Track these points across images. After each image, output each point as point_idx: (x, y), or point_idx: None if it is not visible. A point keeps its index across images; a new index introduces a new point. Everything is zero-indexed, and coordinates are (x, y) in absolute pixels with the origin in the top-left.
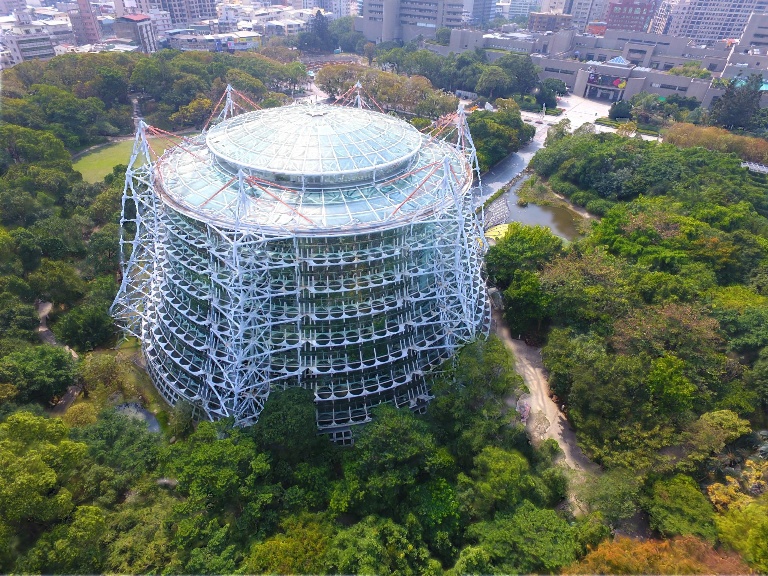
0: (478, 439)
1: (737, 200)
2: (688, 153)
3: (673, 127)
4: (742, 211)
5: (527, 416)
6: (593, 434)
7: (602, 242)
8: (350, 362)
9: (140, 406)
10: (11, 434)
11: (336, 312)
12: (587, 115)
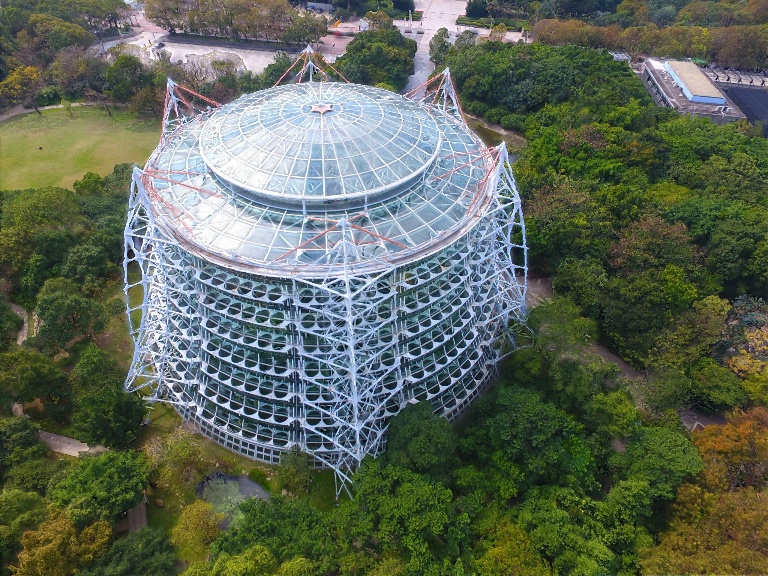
0: (581, 391)
1: (628, 97)
2: (572, 55)
3: (540, 25)
4: (637, 108)
5: None
6: (638, 349)
7: (548, 164)
8: (437, 359)
9: (223, 474)
10: None
11: (424, 321)
12: (445, 15)
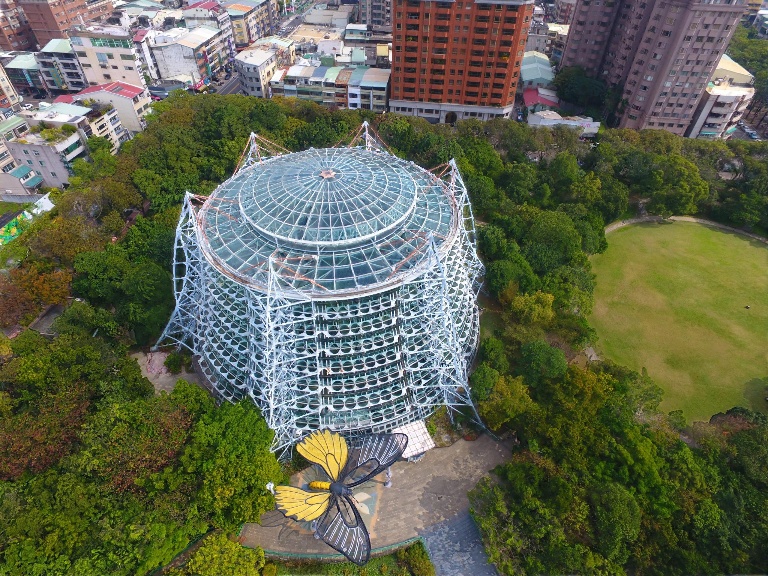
0: None
1: None
2: None
3: None
4: None
5: (147, 366)
6: None
7: None
8: None
9: None
10: None
11: None
12: None
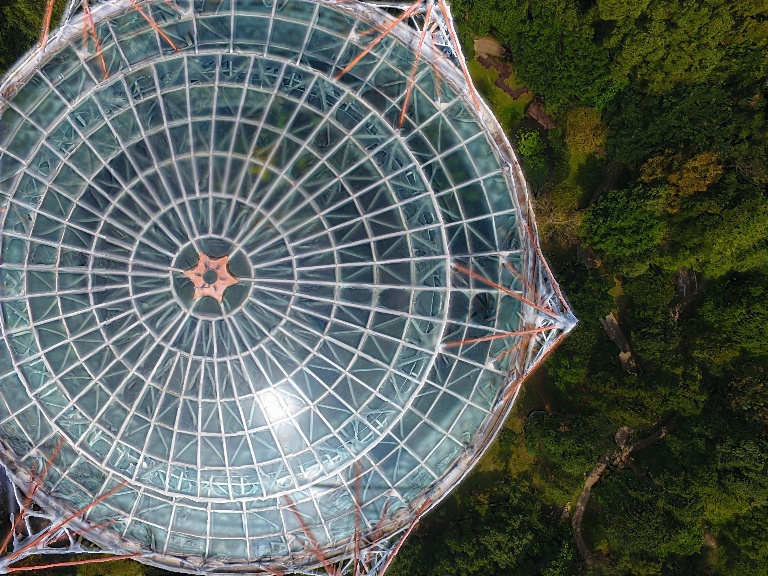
0: None
1: None
2: None
3: None
4: None
5: None
6: None
7: None
8: None
9: None
10: None
11: None
12: None
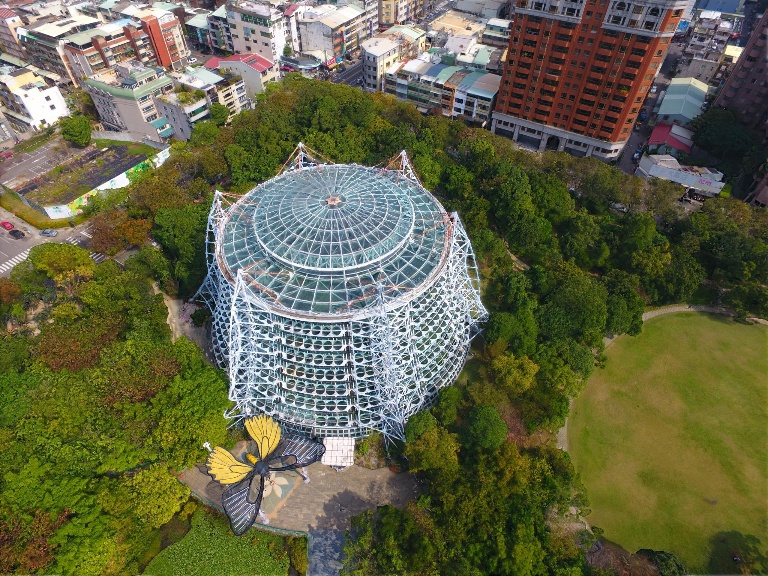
0: None
1: None
2: None
3: None
4: None
5: None
6: None
7: None
8: None
9: None
10: None
11: None
12: None
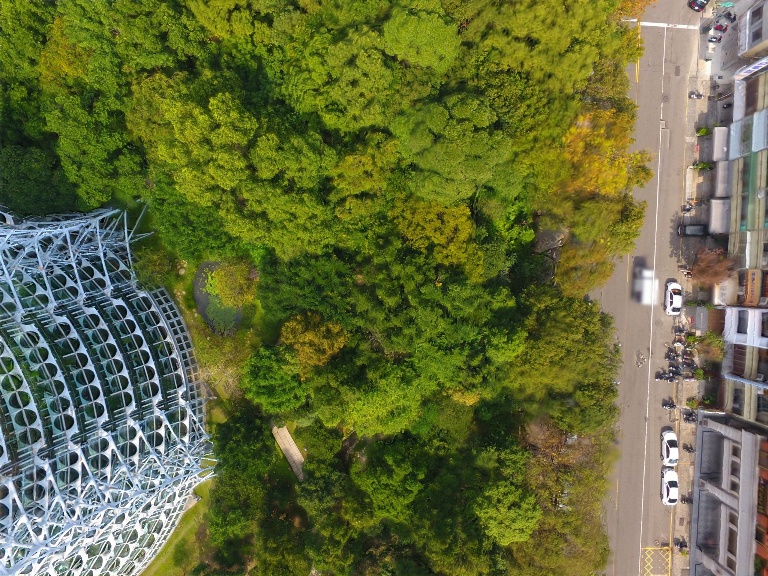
0: None
1: None
2: None
3: None
4: None
5: None
6: None
7: None
8: None
9: (210, 327)
10: (199, 166)
11: None
12: None
